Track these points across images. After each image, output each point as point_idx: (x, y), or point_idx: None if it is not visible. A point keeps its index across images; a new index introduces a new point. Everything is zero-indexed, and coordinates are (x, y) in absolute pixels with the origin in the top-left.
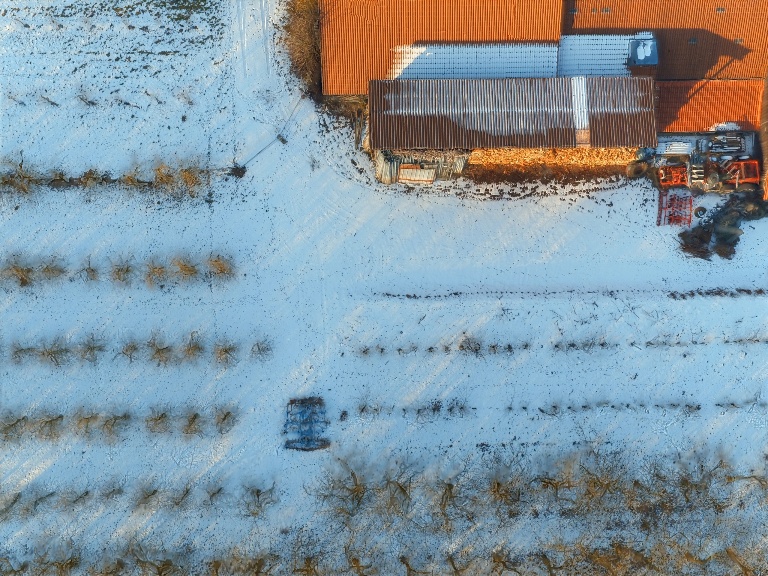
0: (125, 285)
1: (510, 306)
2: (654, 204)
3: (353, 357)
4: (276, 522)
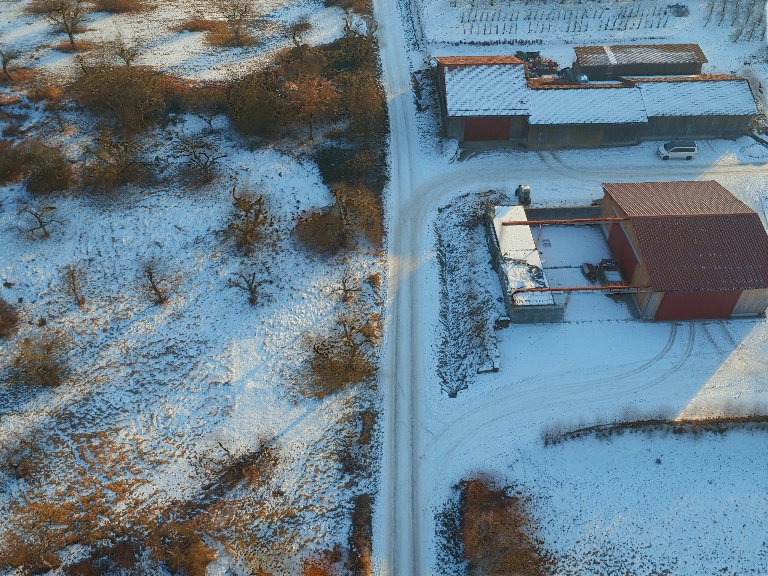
0: None
1: (610, 37)
2: None
3: None
4: None
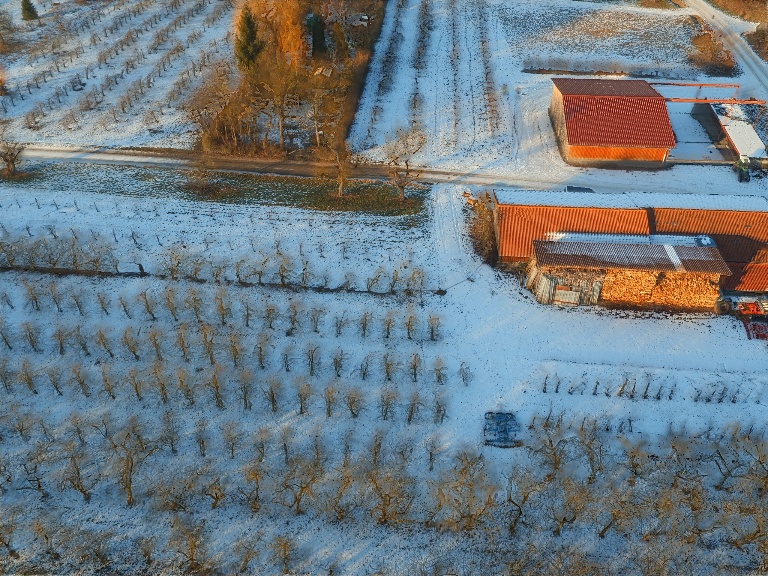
0: (361, 339)
1: (651, 372)
2: (742, 328)
3: (533, 394)
4: (480, 496)
